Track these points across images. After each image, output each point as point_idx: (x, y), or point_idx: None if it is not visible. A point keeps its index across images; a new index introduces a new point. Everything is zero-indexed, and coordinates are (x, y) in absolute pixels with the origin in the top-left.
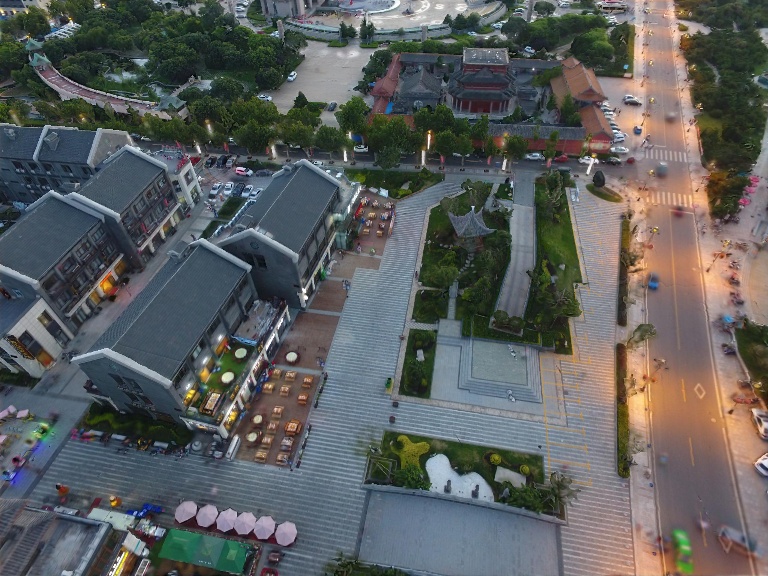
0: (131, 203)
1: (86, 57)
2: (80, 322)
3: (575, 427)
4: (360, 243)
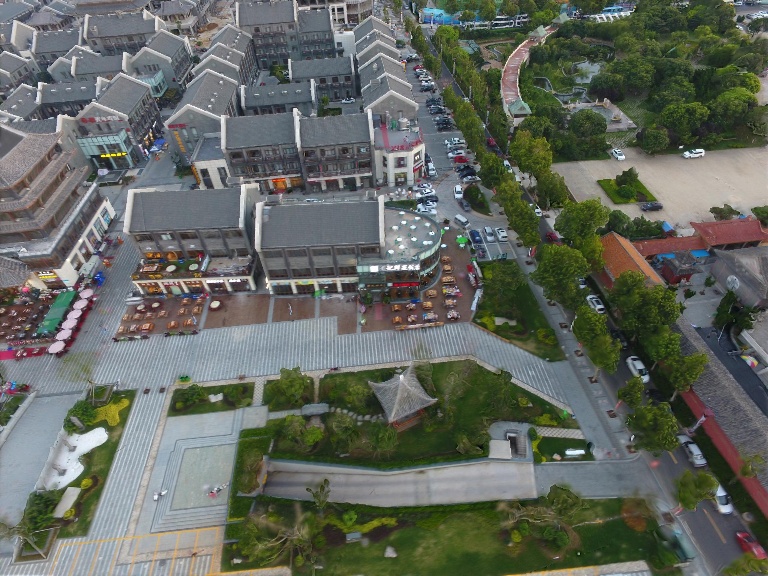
0: (319, 146)
1: (571, 43)
2: None
3: (114, 574)
4: (377, 309)
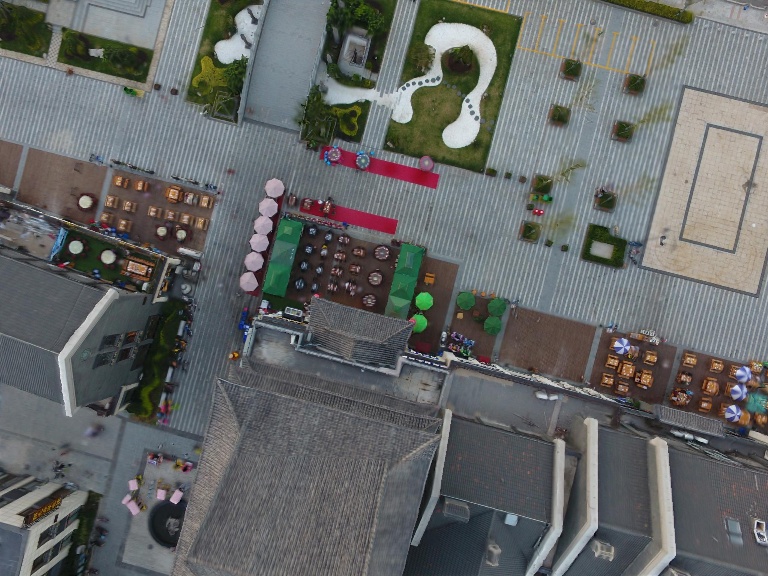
0: None
1: None
2: (7, 477)
3: None
4: None
